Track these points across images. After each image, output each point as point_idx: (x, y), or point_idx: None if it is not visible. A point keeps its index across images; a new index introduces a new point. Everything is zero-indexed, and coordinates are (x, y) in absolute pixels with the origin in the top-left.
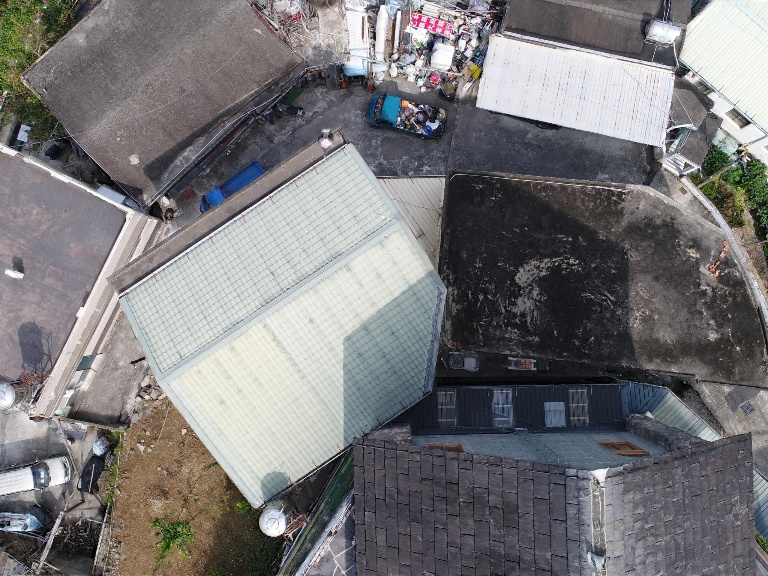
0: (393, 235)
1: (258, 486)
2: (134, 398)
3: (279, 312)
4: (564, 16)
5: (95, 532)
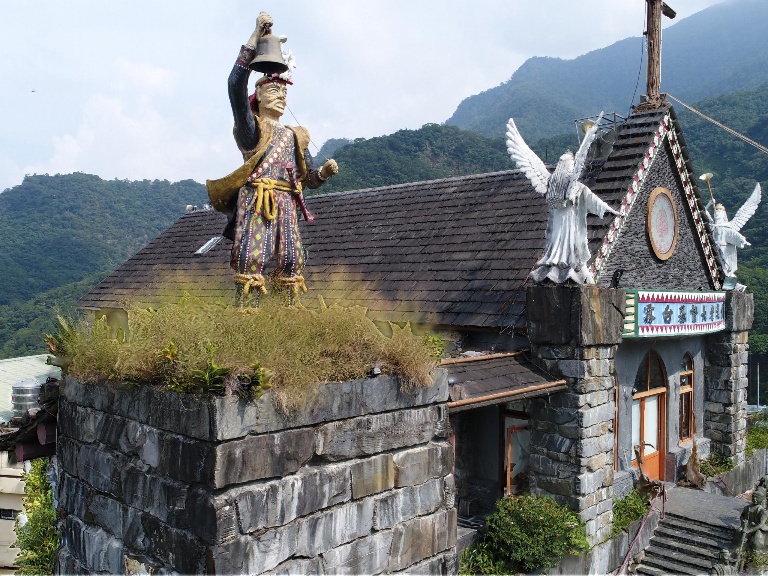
0: None
1: None
2: None
3: None
4: None
5: None
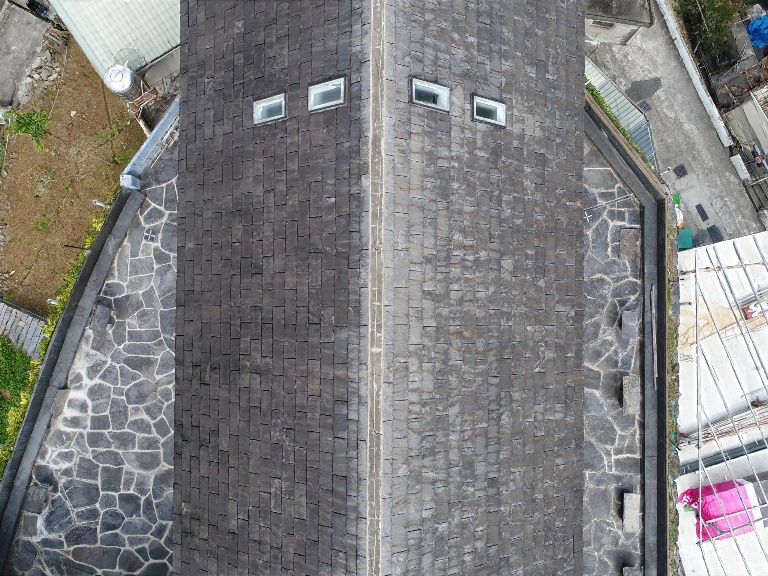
0: None
1: (111, 62)
2: None
3: None
4: None
5: None
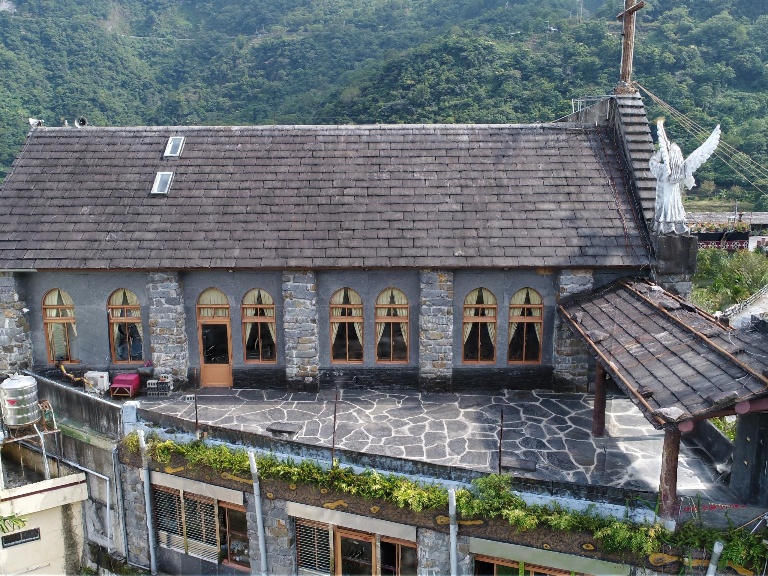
0: None
1: None
2: None
3: None
4: None
5: None
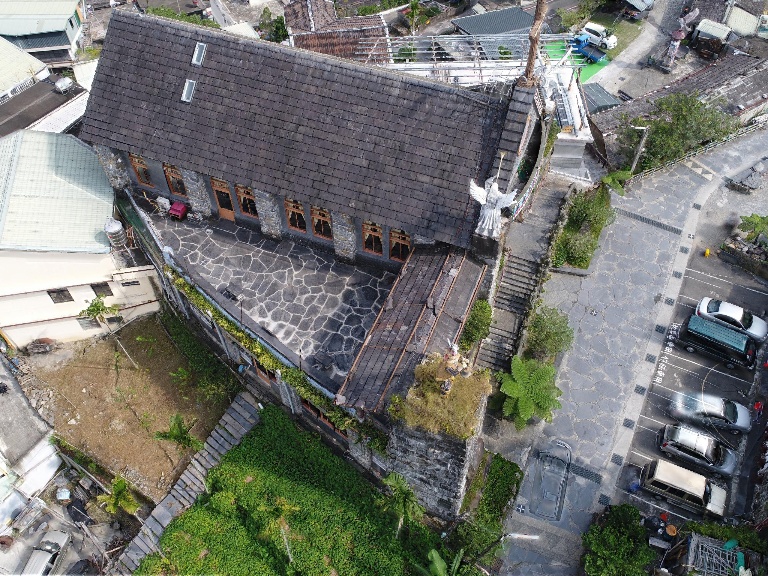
0: (24, 136)
1: (98, 244)
2: (40, 422)
3: (14, 188)
4: (23, 116)
5: (126, 539)
